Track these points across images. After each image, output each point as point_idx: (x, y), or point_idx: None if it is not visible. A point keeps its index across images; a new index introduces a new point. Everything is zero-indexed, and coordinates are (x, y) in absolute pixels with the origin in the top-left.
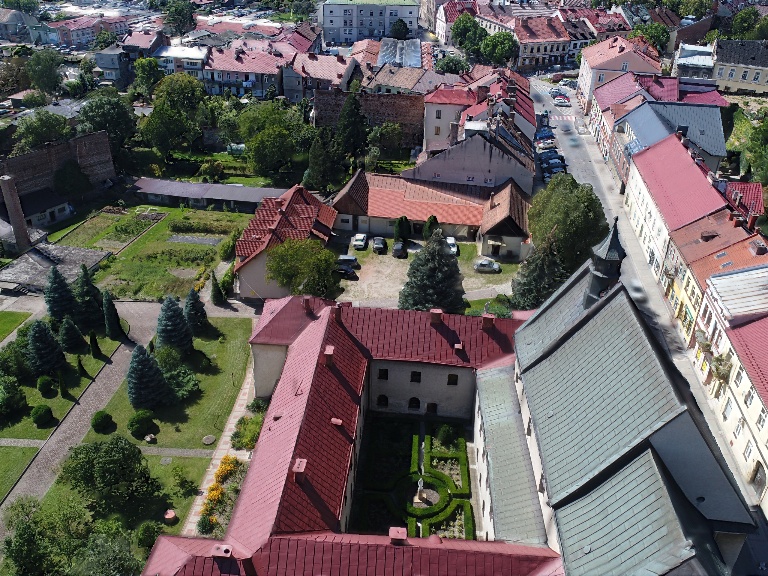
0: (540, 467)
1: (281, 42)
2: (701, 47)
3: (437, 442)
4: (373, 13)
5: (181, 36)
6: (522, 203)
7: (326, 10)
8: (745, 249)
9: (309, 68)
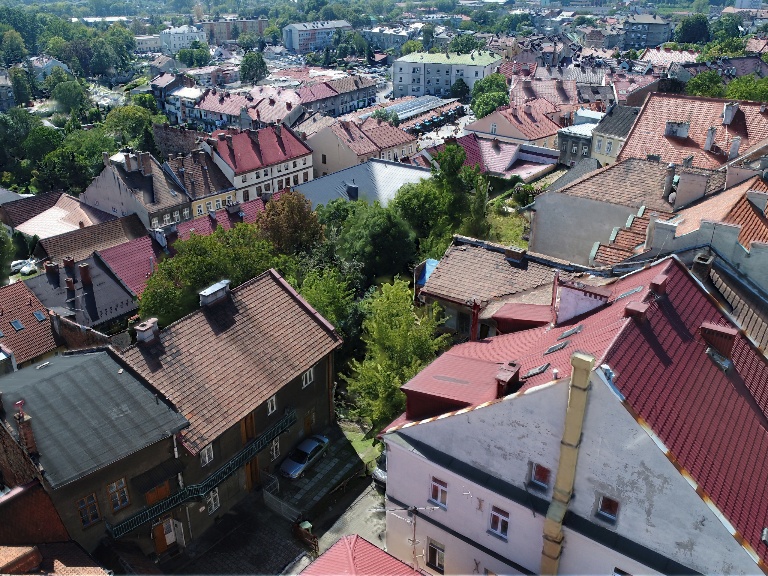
0: None
1: (289, 90)
2: (599, 114)
3: None
4: (440, 72)
5: (253, 83)
6: (112, 237)
7: (396, 67)
8: None
9: (263, 112)
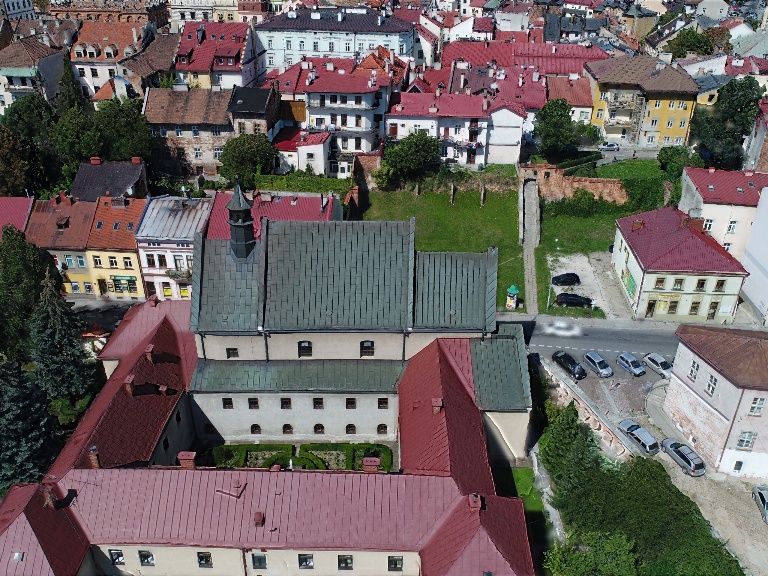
0: (355, 342)
1: None
2: None
3: (222, 465)
4: None
5: None
6: None
7: None
8: (110, 210)
9: None
